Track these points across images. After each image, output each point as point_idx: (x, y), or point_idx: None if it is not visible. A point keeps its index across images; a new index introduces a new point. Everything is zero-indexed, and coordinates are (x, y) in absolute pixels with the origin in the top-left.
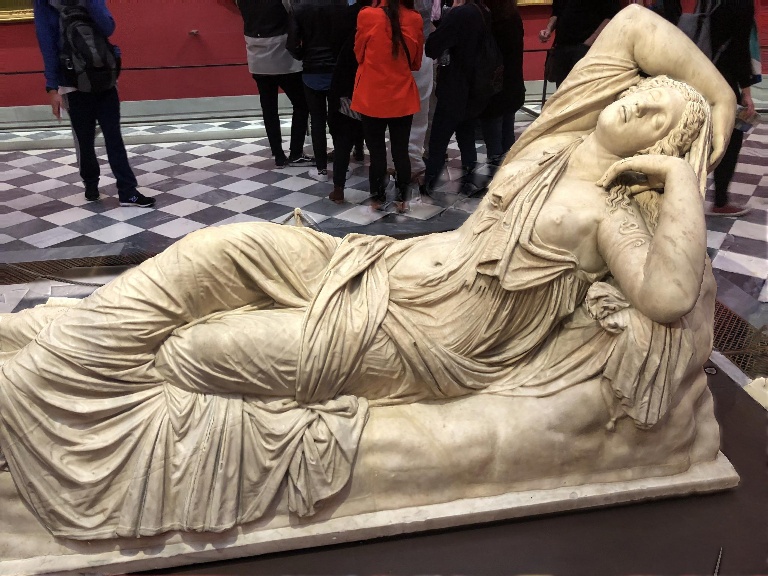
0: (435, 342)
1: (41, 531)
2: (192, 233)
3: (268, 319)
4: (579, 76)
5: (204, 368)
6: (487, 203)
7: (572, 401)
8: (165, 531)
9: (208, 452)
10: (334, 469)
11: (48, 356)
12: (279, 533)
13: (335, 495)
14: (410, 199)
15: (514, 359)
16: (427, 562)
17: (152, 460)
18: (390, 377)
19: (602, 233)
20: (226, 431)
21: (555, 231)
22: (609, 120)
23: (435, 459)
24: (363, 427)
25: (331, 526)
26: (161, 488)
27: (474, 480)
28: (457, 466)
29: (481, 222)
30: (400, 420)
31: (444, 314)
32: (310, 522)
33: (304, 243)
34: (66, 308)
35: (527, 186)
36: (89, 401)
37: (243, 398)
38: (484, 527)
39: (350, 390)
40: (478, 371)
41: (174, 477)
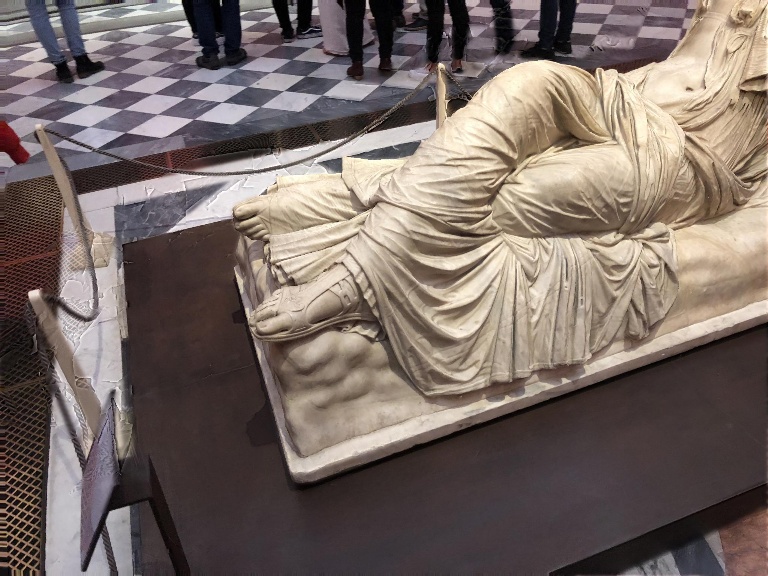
0: (723, 161)
1: (411, 394)
2: (507, 74)
3: (597, 154)
4: None
5: (555, 209)
6: (723, 22)
7: None
8: None
9: (569, 290)
10: None
11: (412, 217)
12: (618, 358)
13: None
14: (461, 57)
15: (763, 173)
16: (744, 360)
17: (516, 307)
18: (684, 201)
19: None
20: (580, 268)
21: None
22: None
23: (738, 269)
24: None
25: (659, 344)
26: None
27: (763, 284)
28: (754, 273)
29: (734, 40)
30: (698, 240)
31: (714, 135)
32: (639, 344)
33: (581, 79)
34: None
35: None
36: (451, 259)
37: (579, 236)
38: None
39: (654, 218)
40: (744, 187)
41: (533, 321)
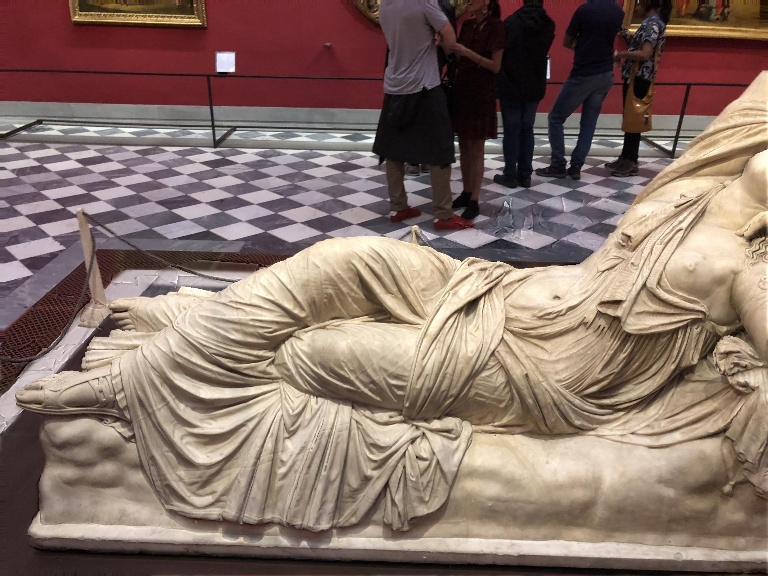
0: (547, 376)
1: (155, 503)
2: None
3: (385, 332)
4: (728, 120)
5: (320, 372)
6: (614, 241)
7: (687, 457)
8: (265, 522)
9: (315, 453)
10: (432, 488)
11: (182, 341)
12: (371, 543)
13: (430, 514)
14: (522, 227)
15: (626, 404)
16: None
17: (262, 452)
18: (497, 405)
19: (738, 285)
20: (334, 435)
21: (687, 278)
22: (759, 168)
23: (535, 495)
24: (465, 451)
25: (422, 545)
26: (267, 480)
27: (573, 523)
28: (557, 505)
29: (607, 260)
30: (502, 450)
31: (558, 349)
32: (402, 537)
33: (425, 262)
34: (197, 298)
35: (660, 228)
36: (212, 388)
37: (352, 405)
38: (578, 573)
39: (456, 412)
40: (588, 411)
41: (280, 472)
